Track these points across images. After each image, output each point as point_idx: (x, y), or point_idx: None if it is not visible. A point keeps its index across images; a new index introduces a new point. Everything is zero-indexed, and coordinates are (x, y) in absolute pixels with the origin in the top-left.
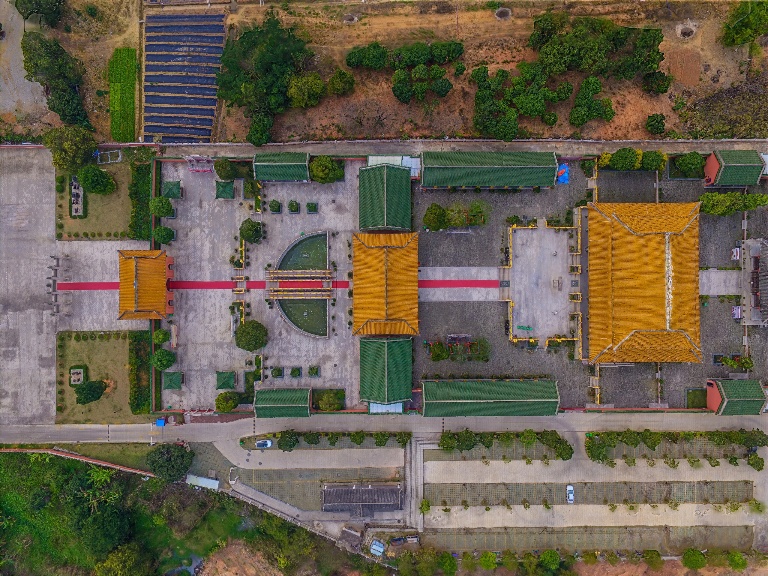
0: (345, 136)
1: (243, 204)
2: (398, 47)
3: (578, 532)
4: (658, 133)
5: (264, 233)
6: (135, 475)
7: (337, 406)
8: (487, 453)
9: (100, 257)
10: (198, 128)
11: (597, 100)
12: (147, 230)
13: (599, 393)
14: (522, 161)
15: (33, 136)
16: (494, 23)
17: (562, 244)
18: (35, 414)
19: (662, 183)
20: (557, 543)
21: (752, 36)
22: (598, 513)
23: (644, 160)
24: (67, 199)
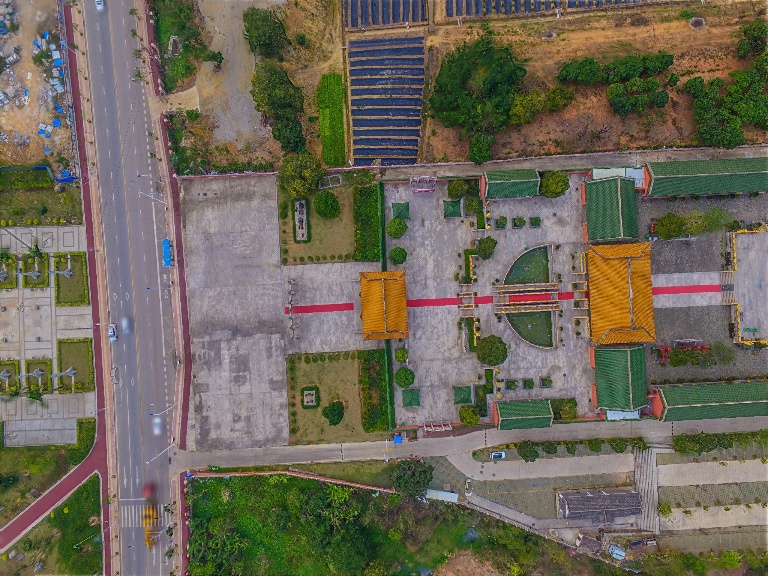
0: (563, 150)
1: (464, 221)
2: (611, 61)
3: None
4: None
5: None
6: (366, 492)
7: (571, 415)
8: (718, 454)
9: (325, 280)
10: (405, 149)
11: None
12: (372, 251)
13: None
14: (747, 167)
15: (254, 164)
16: (690, 33)
17: None
18: (268, 437)
19: None
20: None
21: None
22: None
23: None
24: (290, 224)
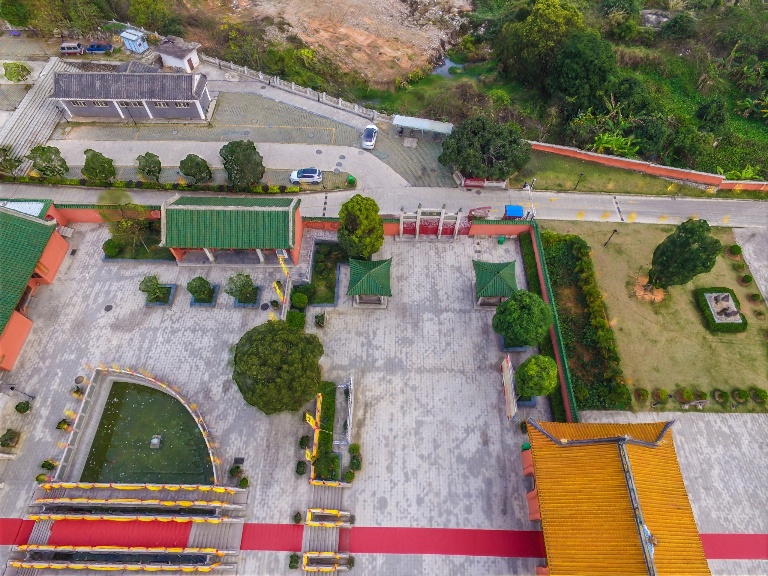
0: None
1: None
2: None
3: None
4: None
5: None
6: None
7: None
8: None
9: None
10: None
11: None
12: None
13: None
14: None
15: None
16: None
17: None
18: None
19: None
20: None
21: None
22: None
23: None
24: None
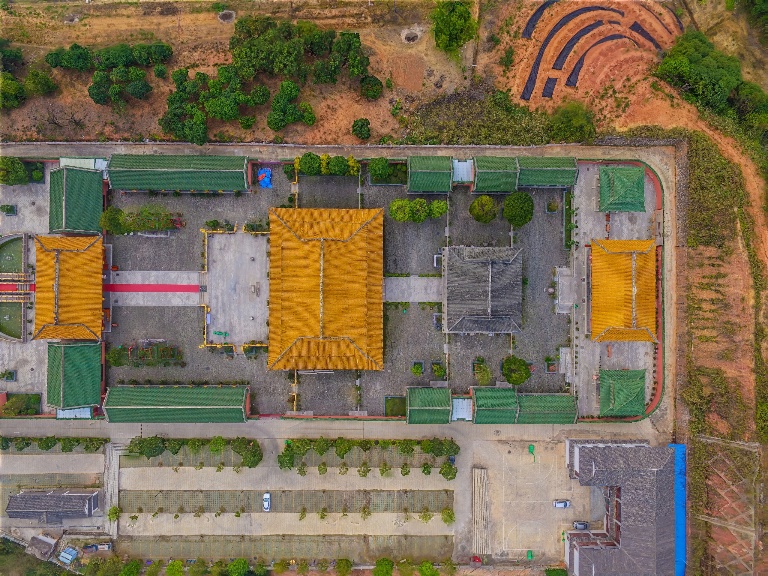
0: (45, 138)
1: None
2: (99, 48)
3: (276, 540)
4: (364, 138)
5: None
6: None
7: (30, 411)
8: (184, 460)
9: None
10: None
11: (292, 104)
12: None
13: (295, 400)
14: (211, 165)
15: None
16: (216, 25)
17: (261, 249)
18: None
19: (364, 189)
20: (255, 551)
21: (456, 42)
22: (296, 521)
23: (329, 165)
24: None
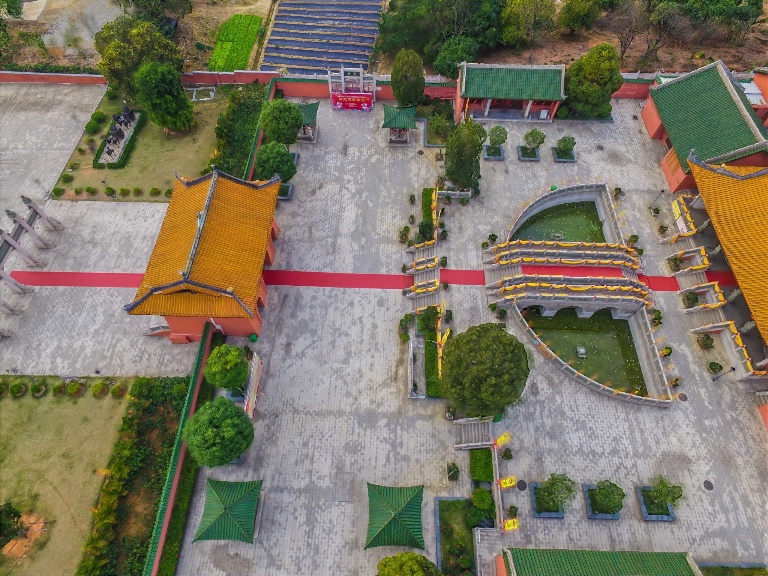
0: None
1: (424, 153)
2: None
3: None
4: None
5: (475, 185)
6: None
7: None
8: None
9: (124, 228)
10: None
11: None
12: None
13: None
14: None
15: None
16: None
17: None
18: None
19: None
20: None
21: None
22: None
23: None
24: (99, 143)
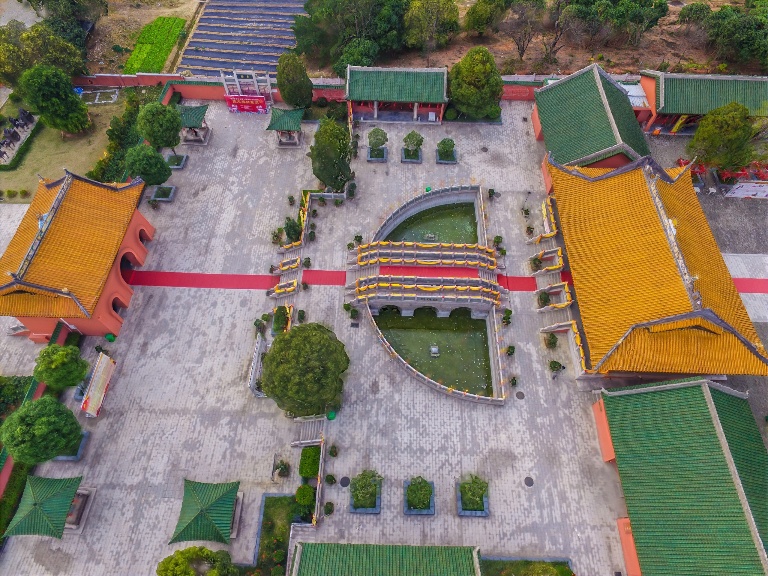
0: None
1: None
2: None
3: None
4: None
5: (351, 187)
6: None
7: None
8: None
9: (6, 230)
10: None
11: None
12: None
13: None
14: None
15: None
16: None
17: None
18: None
19: None
20: None
21: None
22: None
23: None
24: None
